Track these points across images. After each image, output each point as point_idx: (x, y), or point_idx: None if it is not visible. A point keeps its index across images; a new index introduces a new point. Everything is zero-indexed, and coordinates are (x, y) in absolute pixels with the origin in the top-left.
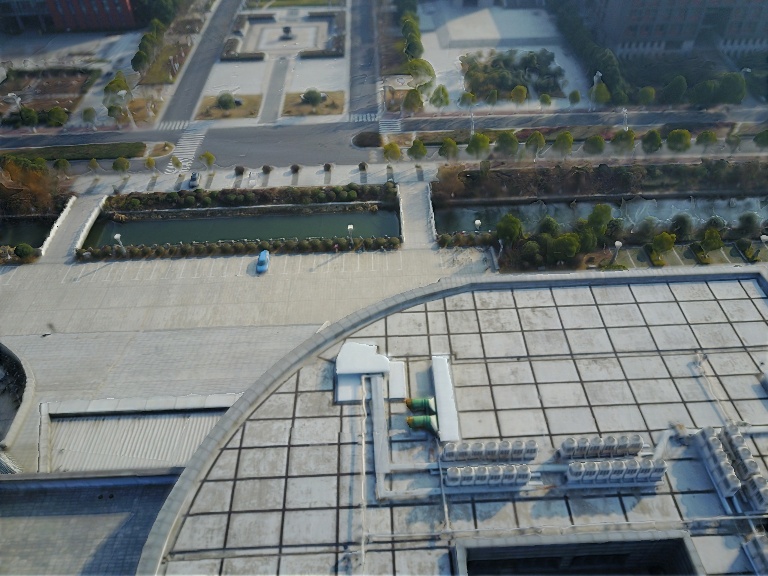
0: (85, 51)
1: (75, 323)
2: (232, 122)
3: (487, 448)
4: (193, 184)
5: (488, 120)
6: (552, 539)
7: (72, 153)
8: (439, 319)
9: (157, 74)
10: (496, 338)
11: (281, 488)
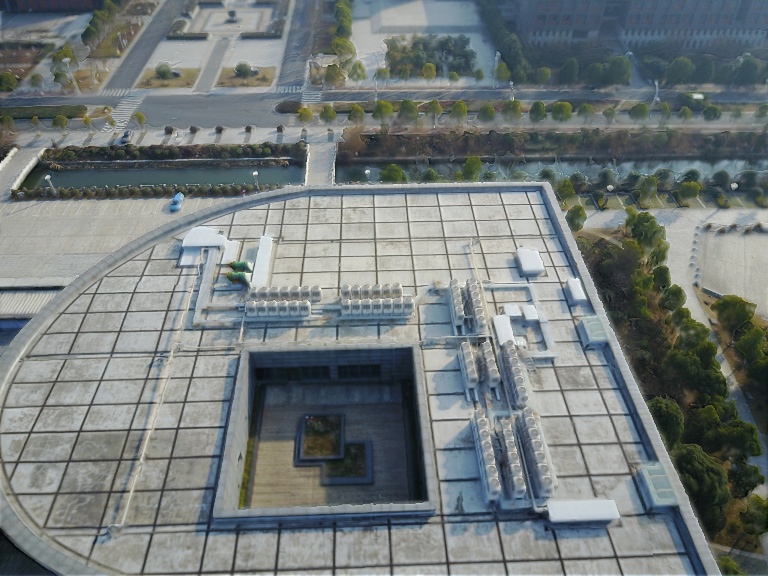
0: (43, 28)
1: (4, 247)
2: (169, 91)
3: (281, 290)
4: (125, 140)
5: (401, 94)
6: (315, 347)
7: (18, 113)
8: (277, 214)
9: (106, 49)
10: (319, 227)
11: (121, 318)
